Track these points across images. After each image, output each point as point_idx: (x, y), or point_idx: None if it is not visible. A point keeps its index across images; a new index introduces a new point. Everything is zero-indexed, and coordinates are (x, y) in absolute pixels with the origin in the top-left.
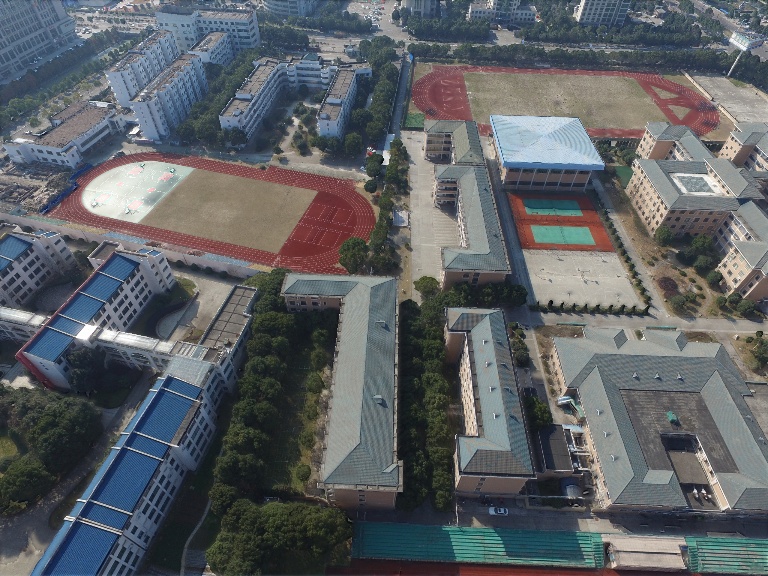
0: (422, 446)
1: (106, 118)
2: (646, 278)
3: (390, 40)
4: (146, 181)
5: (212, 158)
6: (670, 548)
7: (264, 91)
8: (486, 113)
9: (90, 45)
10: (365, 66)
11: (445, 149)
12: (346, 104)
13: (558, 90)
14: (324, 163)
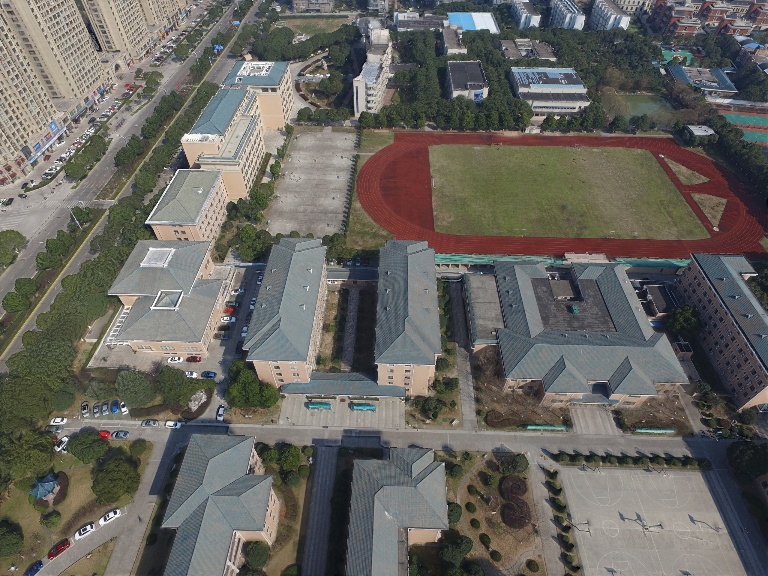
0: (767, 292)
1: None
2: (546, 528)
3: None
4: None
5: None
6: (573, 260)
7: None
8: None
9: None
10: None
11: None
12: None
13: None
14: None
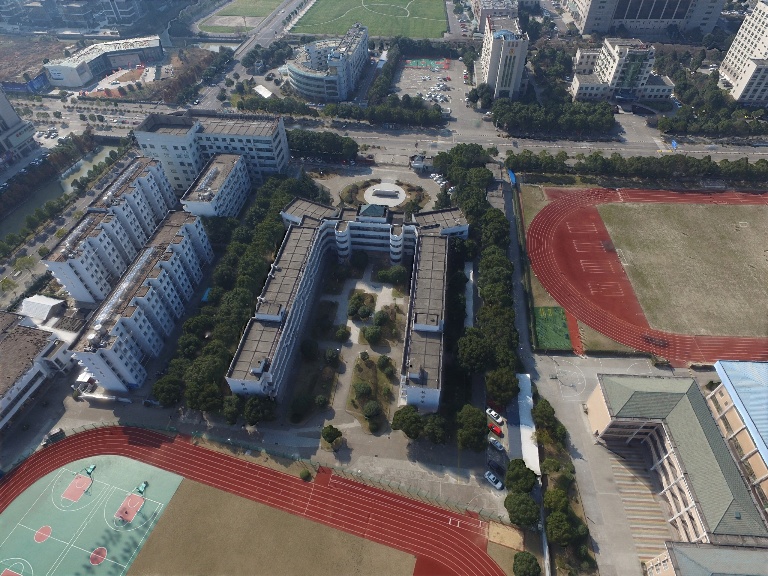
0: None
1: (37, 358)
2: None
3: (479, 151)
4: (92, 523)
5: (215, 445)
6: None
7: (301, 286)
8: (664, 303)
9: (50, 164)
10: (457, 218)
11: (640, 433)
12: (443, 319)
13: (760, 242)
14: (415, 457)
